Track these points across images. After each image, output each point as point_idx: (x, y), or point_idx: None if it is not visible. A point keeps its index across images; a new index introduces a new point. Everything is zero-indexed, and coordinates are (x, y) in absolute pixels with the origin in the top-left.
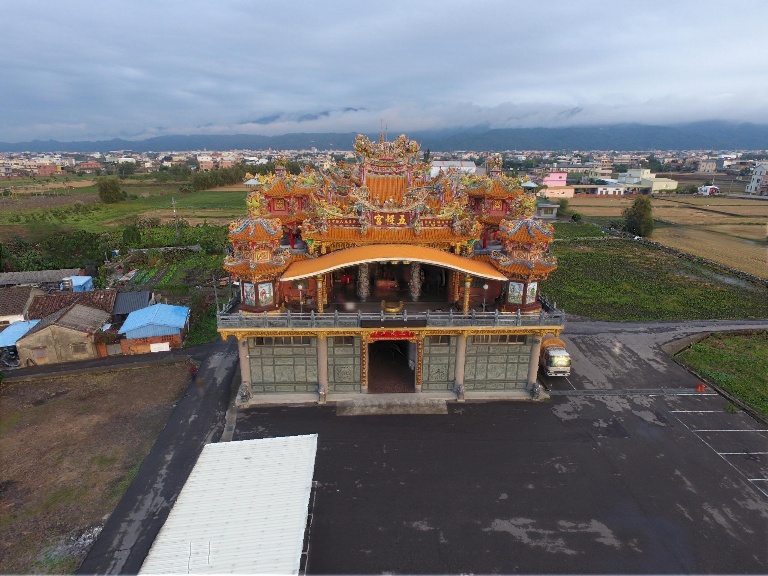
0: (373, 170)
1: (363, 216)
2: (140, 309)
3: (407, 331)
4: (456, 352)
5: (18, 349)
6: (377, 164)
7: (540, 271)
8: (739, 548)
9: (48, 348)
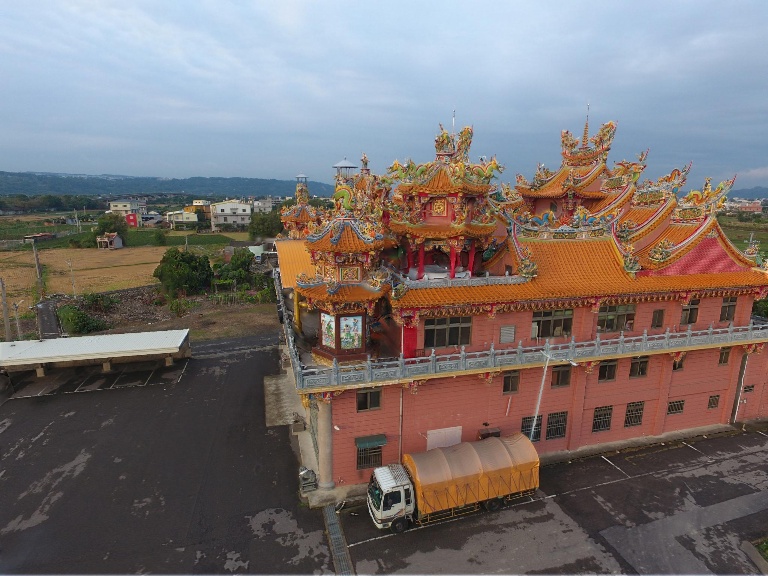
0: None
1: None
2: None
3: None
4: None
5: None
6: None
7: (307, 293)
8: None
9: None
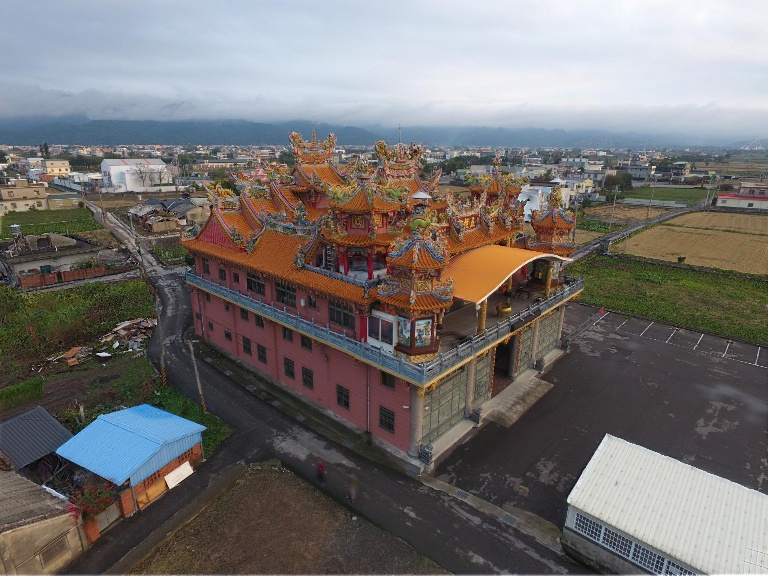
0: (391, 174)
1: (460, 223)
2: (72, 438)
3: None
4: (534, 332)
5: None
6: (394, 167)
7: None
8: (749, 381)
9: None
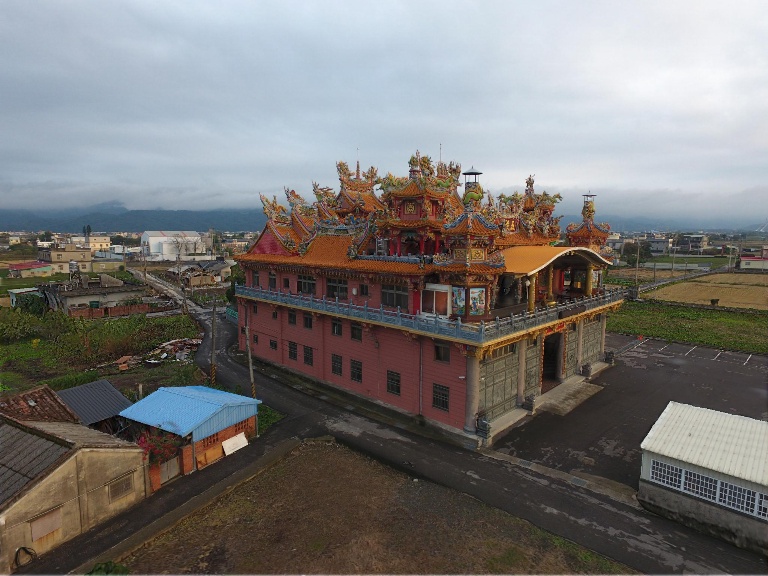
0: None
1: None
2: (134, 404)
3: (571, 319)
4: (578, 336)
5: (0, 532)
6: None
7: None
8: None
9: (64, 506)
